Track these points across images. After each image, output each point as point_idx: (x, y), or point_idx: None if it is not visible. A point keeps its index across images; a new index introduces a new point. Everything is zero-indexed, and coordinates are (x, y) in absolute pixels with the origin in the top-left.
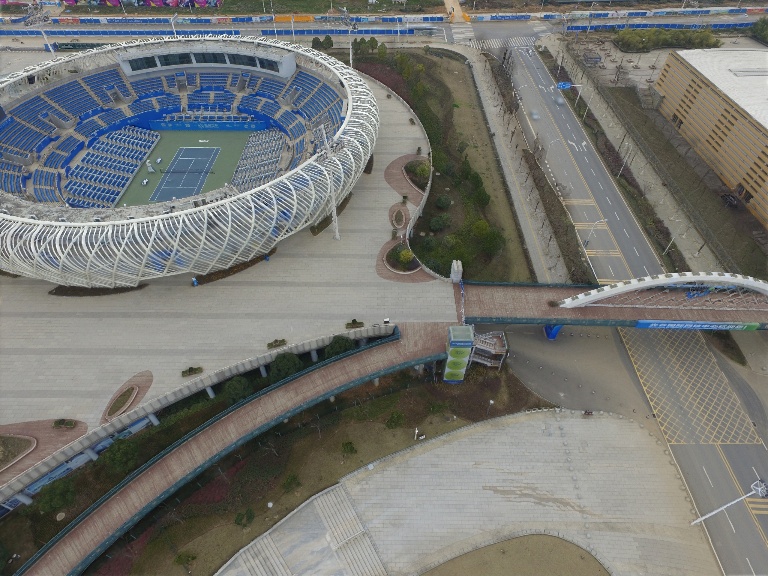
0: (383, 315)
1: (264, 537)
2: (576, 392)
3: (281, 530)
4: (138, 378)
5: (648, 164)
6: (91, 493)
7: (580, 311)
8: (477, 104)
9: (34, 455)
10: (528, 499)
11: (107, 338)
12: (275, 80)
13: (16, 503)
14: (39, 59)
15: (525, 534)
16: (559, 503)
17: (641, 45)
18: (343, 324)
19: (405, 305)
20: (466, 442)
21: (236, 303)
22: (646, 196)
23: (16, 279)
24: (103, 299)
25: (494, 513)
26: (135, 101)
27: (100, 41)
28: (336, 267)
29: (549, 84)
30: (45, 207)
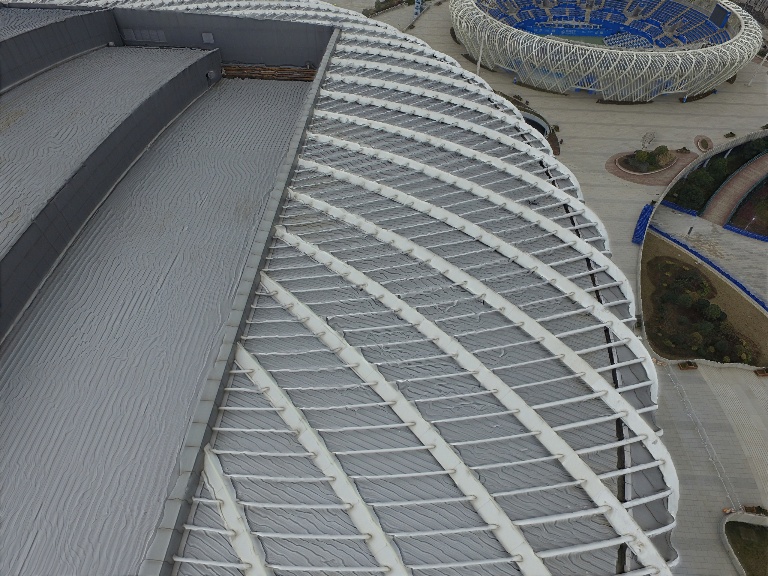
0: None
1: None
2: None
3: None
4: (700, 137)
5: None
6: None
7: None
8: None
9: (681, 161)
10: None
11: (659, 121)
12: None
13: None
14: None
15: None
16: None
17: None
18: None
19: None
20: None
21: (719, 111)
22: None
23: (567, 96)
24: (634, 106)
25: None
26: (519, 11)
27: None
28: (763, 98)
29: None
30: None
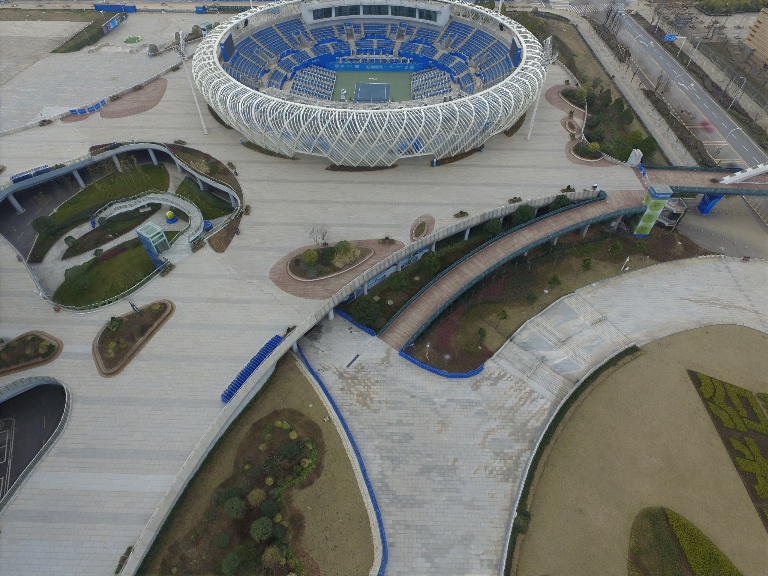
0: (586, 185)
1: (538, 317)
2: (733, 247)
3: (547, 314)
4: (423, 218)
5: (752, 100)
6: (405, 291)
7: (736, 186)
8: (591, 55)
9: (376, 257)
10: (715, 305)
11: (386, 196)
12: (430, 29)
13: (358, 293)
14: (193, 19)
15: (719, 323)
16: (739, 308)
17: (725, 9)
18: (558, 190)
19: (600, 180)
20: (659, 273)
21: (471, 177)
22: (756, 122)
23: (296, 161)
24: (369, 173)
25: (693, 312)
26: (315, 45)
27: (238, 5)
28: (536, 157)
29: (648, 40)
30: (329, 102)
